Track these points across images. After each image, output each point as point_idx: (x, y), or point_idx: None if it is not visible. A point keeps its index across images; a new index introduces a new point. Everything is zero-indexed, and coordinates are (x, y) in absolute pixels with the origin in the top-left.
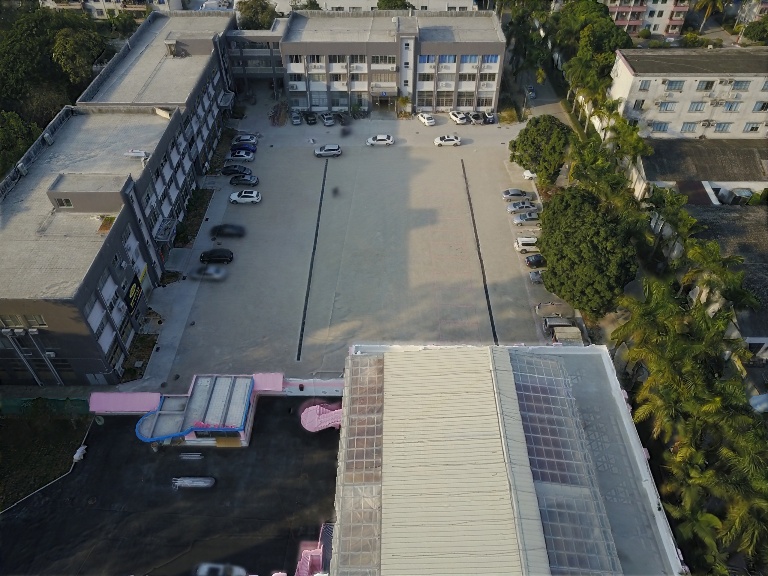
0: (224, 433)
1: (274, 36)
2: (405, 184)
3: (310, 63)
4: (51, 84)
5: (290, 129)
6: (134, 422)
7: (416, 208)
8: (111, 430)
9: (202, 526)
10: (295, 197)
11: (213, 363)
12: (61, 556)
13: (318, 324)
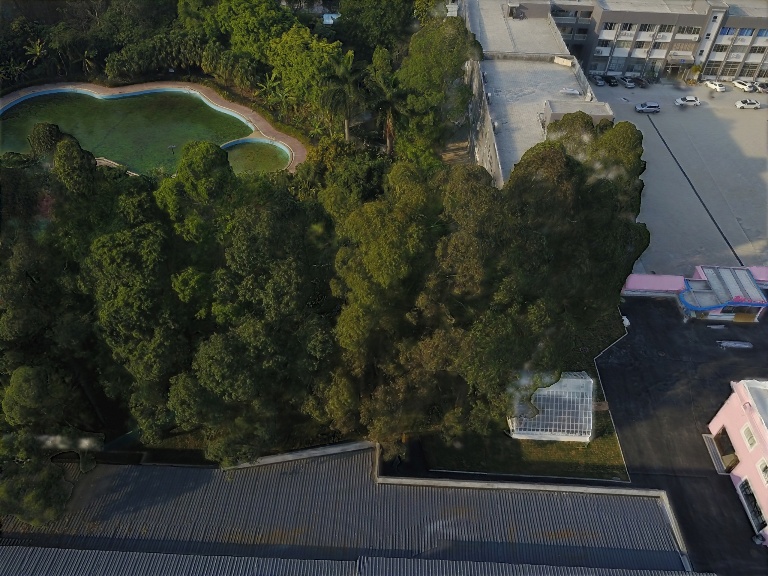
0: (746, 309)
1: (585, 6)
2: (733, 137)
3: (622, 30)
4: (406, 37)
5: (597, 89)
6: (650, 302)
7: (757, 156)
8: (636, 306)
9: (765, 374)
10: (643, 143)
11: (675, 264)
12: (669, 389)
13: (739, 240)
